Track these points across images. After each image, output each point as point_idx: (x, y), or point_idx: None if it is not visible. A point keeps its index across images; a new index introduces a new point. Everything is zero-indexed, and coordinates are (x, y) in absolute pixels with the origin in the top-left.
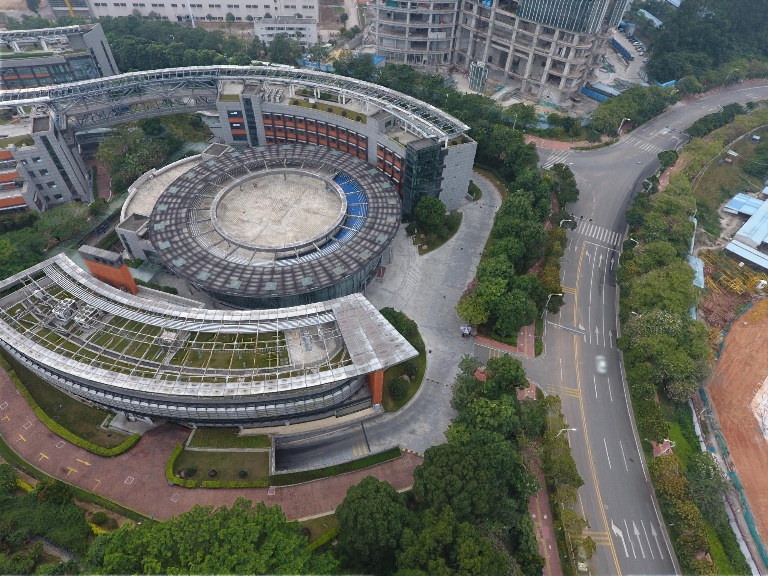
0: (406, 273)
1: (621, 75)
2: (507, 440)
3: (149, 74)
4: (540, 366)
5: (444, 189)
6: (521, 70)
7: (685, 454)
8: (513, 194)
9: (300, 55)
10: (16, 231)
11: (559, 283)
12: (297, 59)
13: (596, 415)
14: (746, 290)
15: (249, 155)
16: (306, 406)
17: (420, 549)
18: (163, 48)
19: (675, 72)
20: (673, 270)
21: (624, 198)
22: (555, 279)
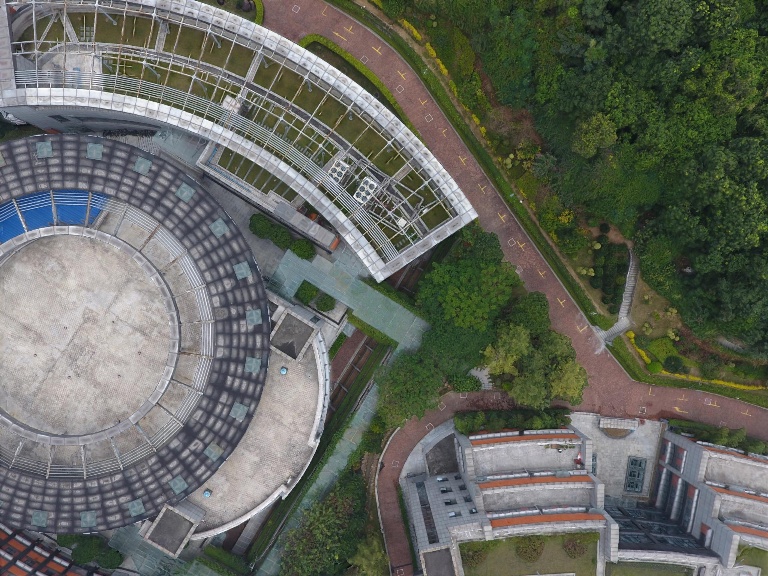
0: None
1: None
2: None
3: None
4: None
5: None
6: None
7: None
8: None
9: None
10: (463, 364)
11: None
12: None
13: None
14: None
15: (112, 502)
16: None
17: None
18: None
19: None
20: None
21: None
22: None
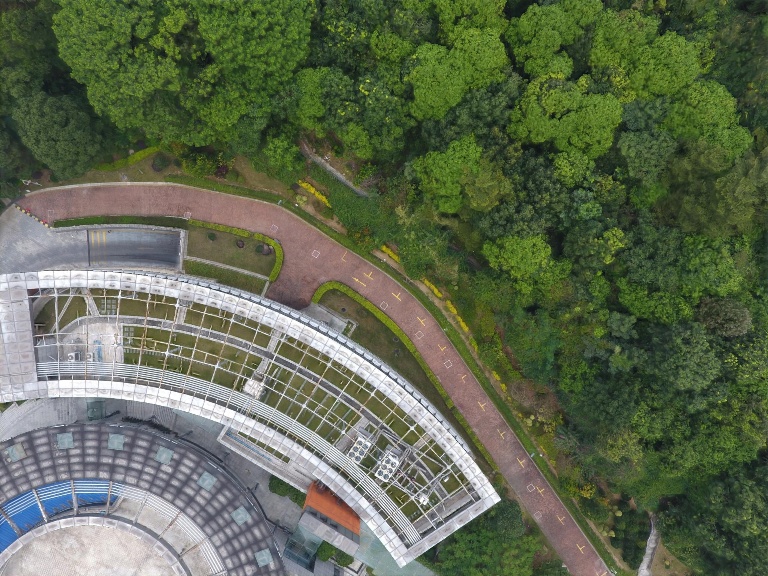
0: None
1: None
2: None
3: None
4: None
5: None
6: None
7: None
8: None
9: None
10: None
11: None
12: None
13: None
14: None
15: None
16: None
17: (8, 78)
18: None
19: None
20: None
21: None
22: None
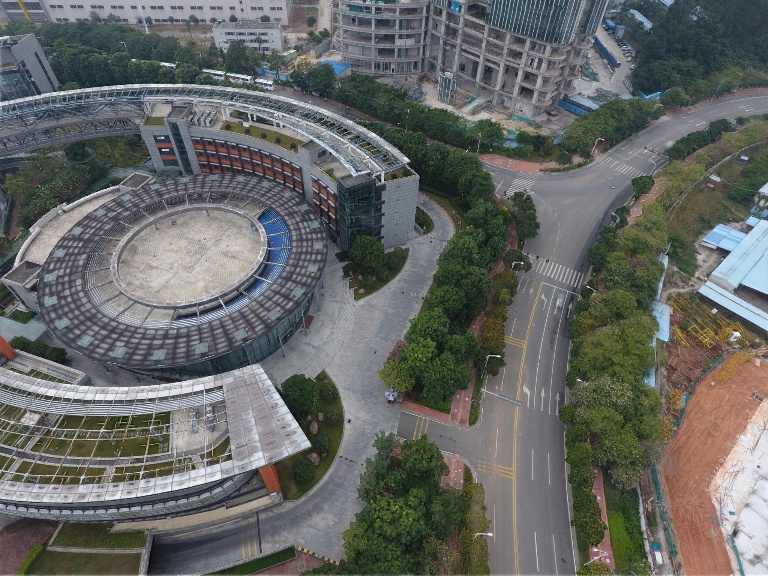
0: (335, 323)
1: (605, 84)
2: (405, 554)
3: (69, 95)
4: (473, 438)
5: (386, 225)
6: (494, 80)
7: (626, 554)
8: (461, 231)
9: (258, 63)
10: None
11: (502, 338)
12: (256, 67)
13: (529, 501)
14: (718, 342)
15: (170, 187)
16: (179, 506)
17: None
18: (107, 58)
19: (661, 83)
20: (630, 326)
21: (592, 230)
22: (498, 334)
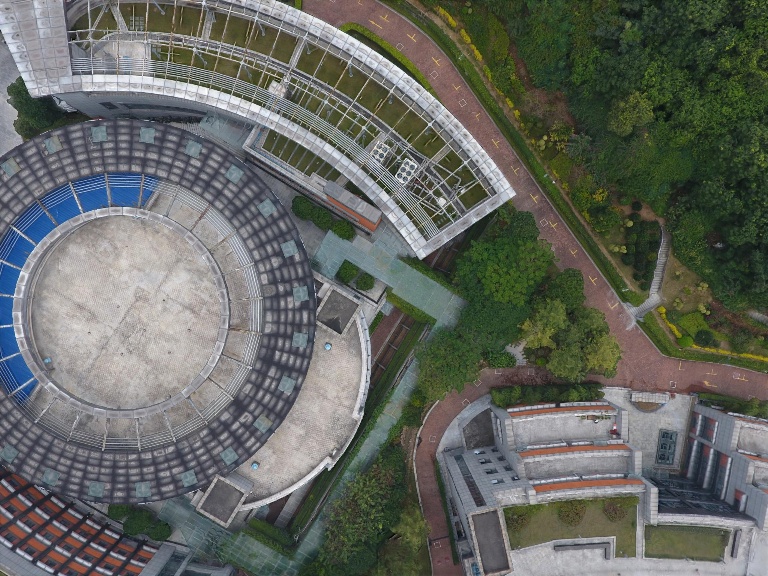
0: None
1: None
2: None
3: None
4: None
5: None
6: None
7: None
8: None
9: None
10: (501, 339)
11: None
12: None
13: None
14: None
15: (165, 473)
16: None
17: None
18: None
19: None
20: None
21: None
22: None
